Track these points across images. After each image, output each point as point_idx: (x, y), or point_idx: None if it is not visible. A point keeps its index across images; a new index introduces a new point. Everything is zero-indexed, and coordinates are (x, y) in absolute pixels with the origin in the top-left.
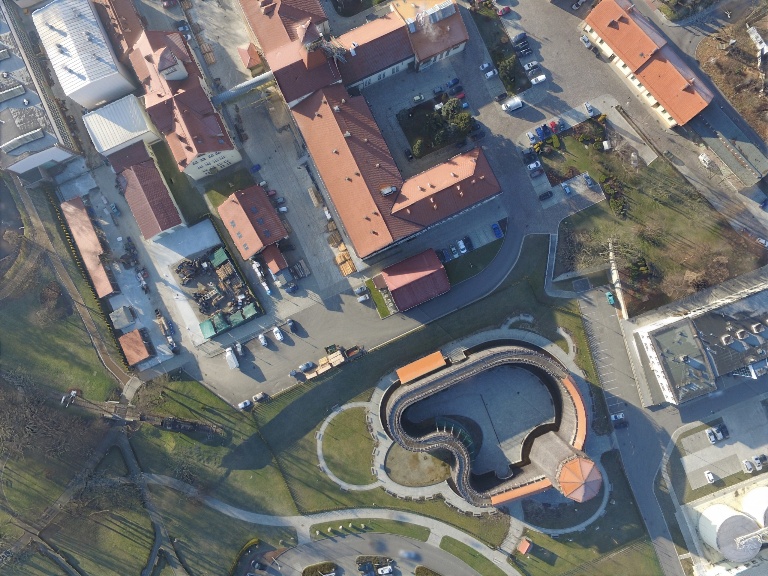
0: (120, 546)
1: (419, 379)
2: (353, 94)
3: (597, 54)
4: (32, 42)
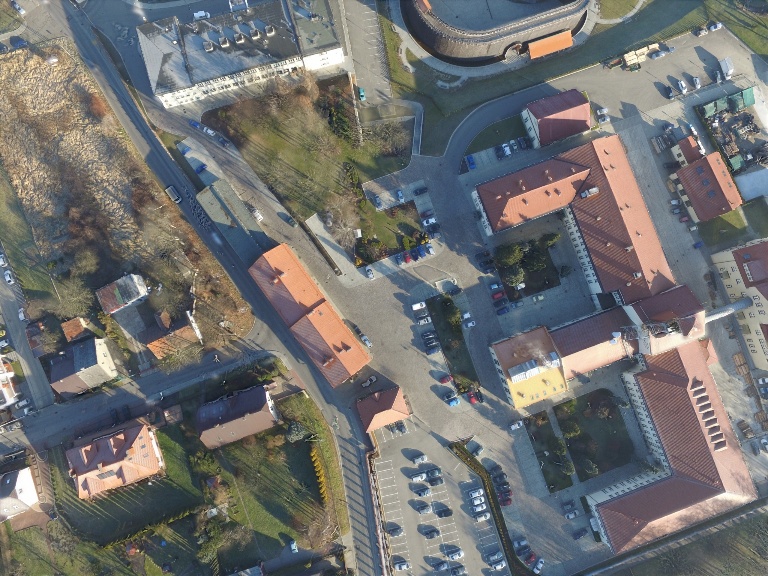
0: None
1: (554, 33)
2: (608, 302)
3: (357, 328)
4: None
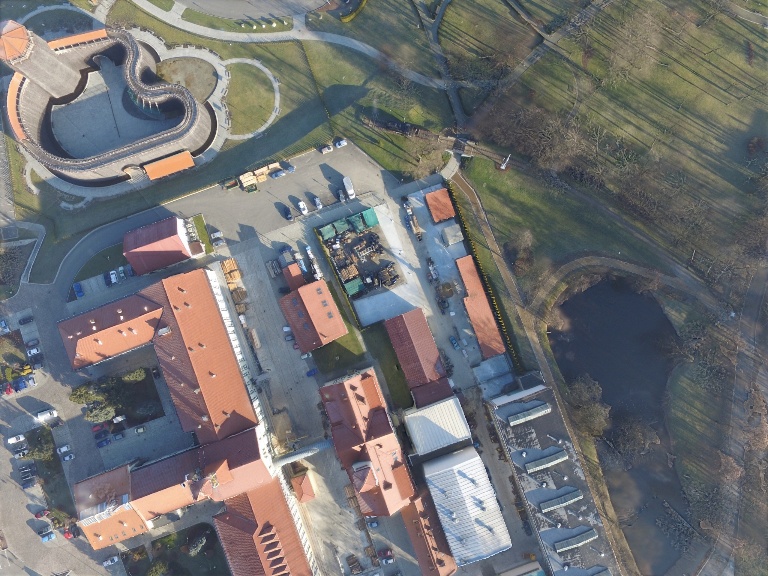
0: (471, 25)
1: (172, 154)
2: None
3: None
4: (529, 524)
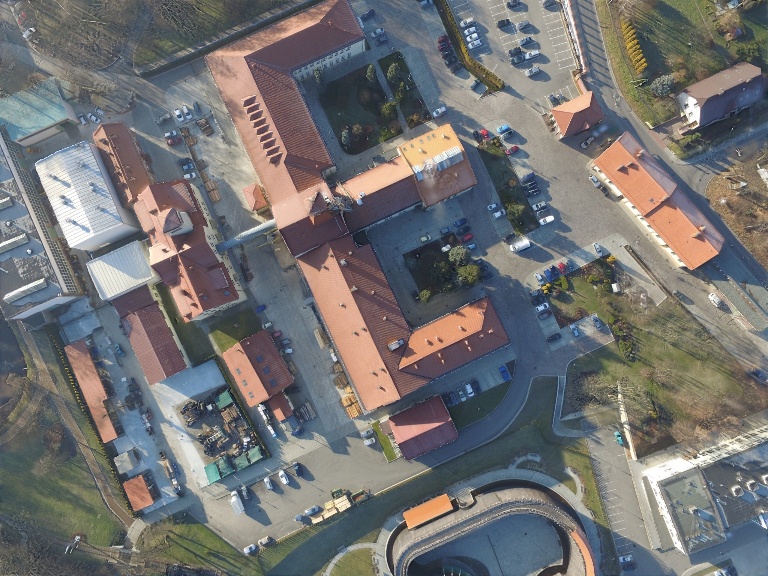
0: None
1: (426, 524)
2: (360, 238)
3: (606, 194)
4: (35, 180)
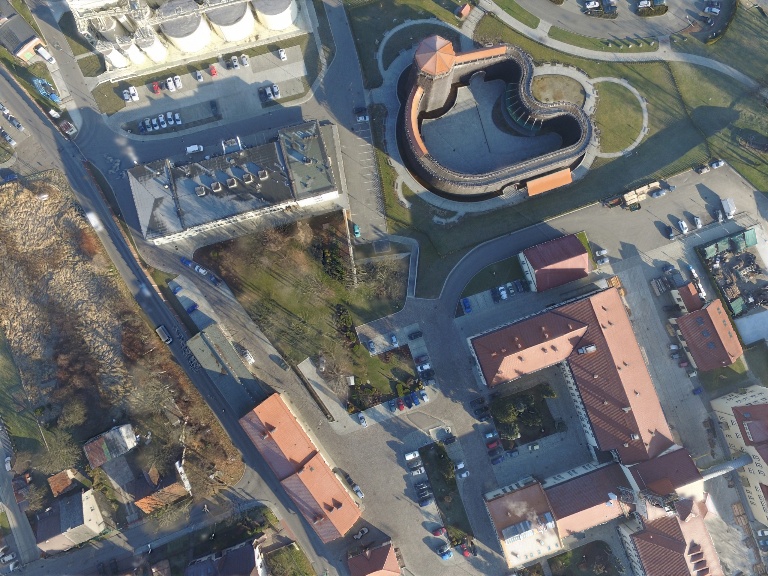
0: None
1: (553, 171)
2: (605, 456)
3: (349, 477)
4: None
